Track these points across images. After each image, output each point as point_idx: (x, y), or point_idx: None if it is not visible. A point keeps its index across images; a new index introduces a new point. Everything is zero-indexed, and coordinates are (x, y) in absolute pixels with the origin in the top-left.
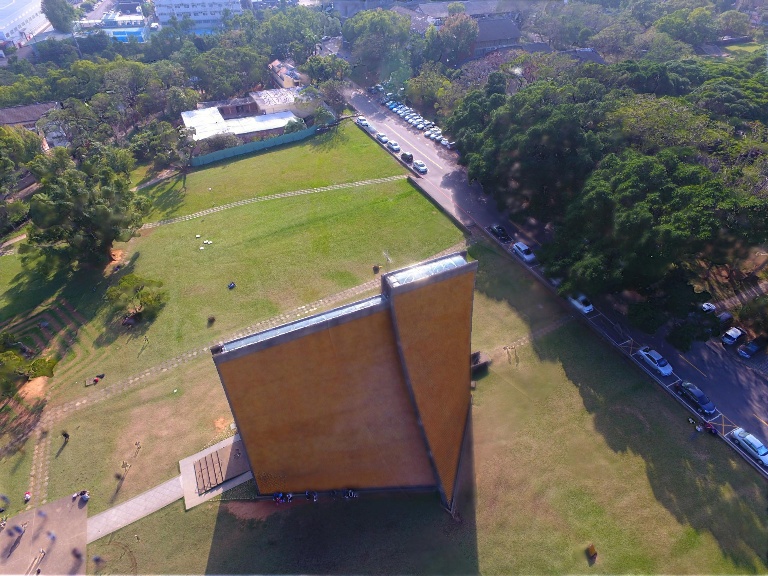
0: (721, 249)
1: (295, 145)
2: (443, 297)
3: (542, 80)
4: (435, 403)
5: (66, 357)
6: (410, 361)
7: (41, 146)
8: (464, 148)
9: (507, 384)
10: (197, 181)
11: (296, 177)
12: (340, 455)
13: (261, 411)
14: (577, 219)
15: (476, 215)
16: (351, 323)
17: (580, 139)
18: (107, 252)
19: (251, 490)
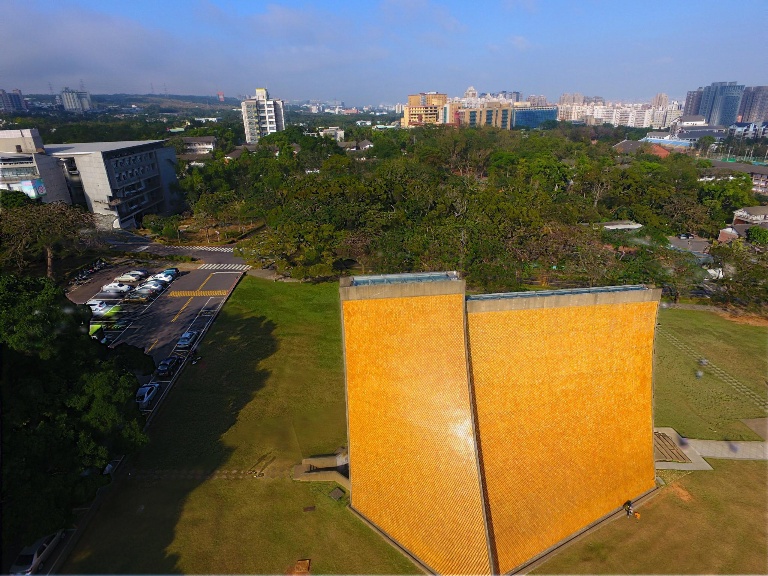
0: None
1: None
2: None
3: None
4: None
5: None
6: None
7: None
8: None
9: (301, 441)
10: None
11: None
12: None
13: None
14: None
15: None
16: None
17: None
18: None
19: None
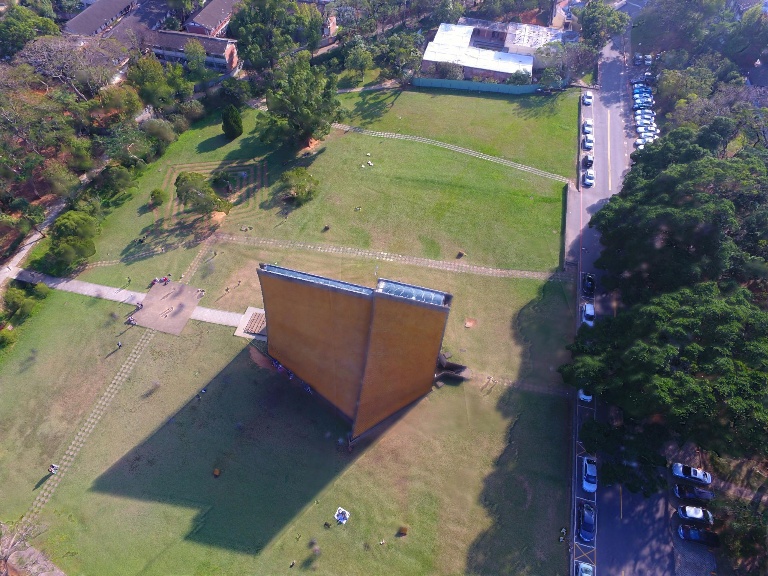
0: (706, 436)
1: (506, 98)
2: (416, 316)
3: (767, 153)
4: (381, 377)
5: (244, 204)
6: (374, 342)
7: (328, 21)
8: (624, 186)
9: (464, 402)
10: (405, 102)
11: (478, 134)
12: (313, 365)
13: (279, 312)
14: (626, 321)
15: (588, 256)
16: (346, 296)
17: (713, 247)
18: (306, 140)
19: (266, 348)
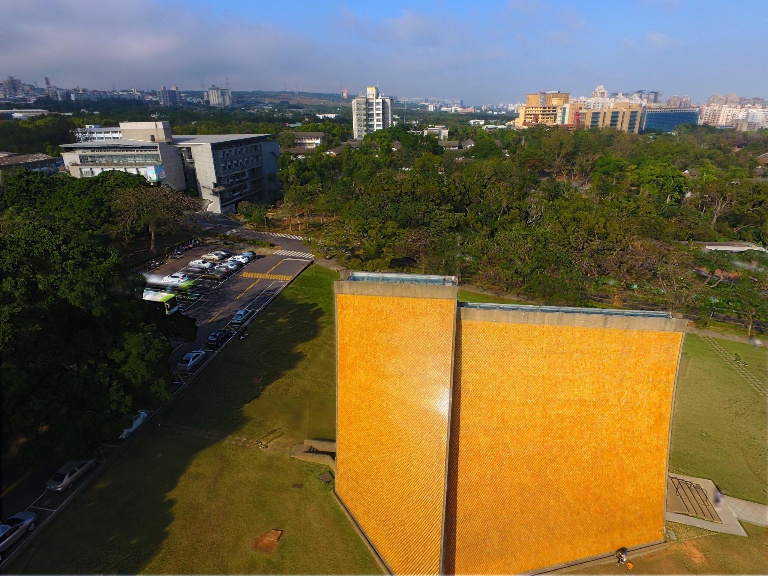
0: None
1: None
2: None
3: None
4: None
5: None
6: None
7: None
8: None
9: (311, 423)
10: None
11: None
12: None
13: None
14: None
15: None
16: None
17: None
18: None
19: None
